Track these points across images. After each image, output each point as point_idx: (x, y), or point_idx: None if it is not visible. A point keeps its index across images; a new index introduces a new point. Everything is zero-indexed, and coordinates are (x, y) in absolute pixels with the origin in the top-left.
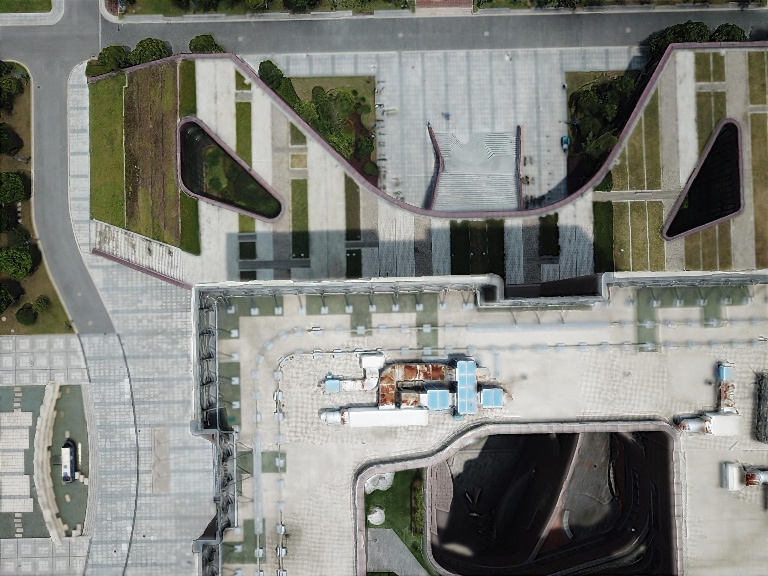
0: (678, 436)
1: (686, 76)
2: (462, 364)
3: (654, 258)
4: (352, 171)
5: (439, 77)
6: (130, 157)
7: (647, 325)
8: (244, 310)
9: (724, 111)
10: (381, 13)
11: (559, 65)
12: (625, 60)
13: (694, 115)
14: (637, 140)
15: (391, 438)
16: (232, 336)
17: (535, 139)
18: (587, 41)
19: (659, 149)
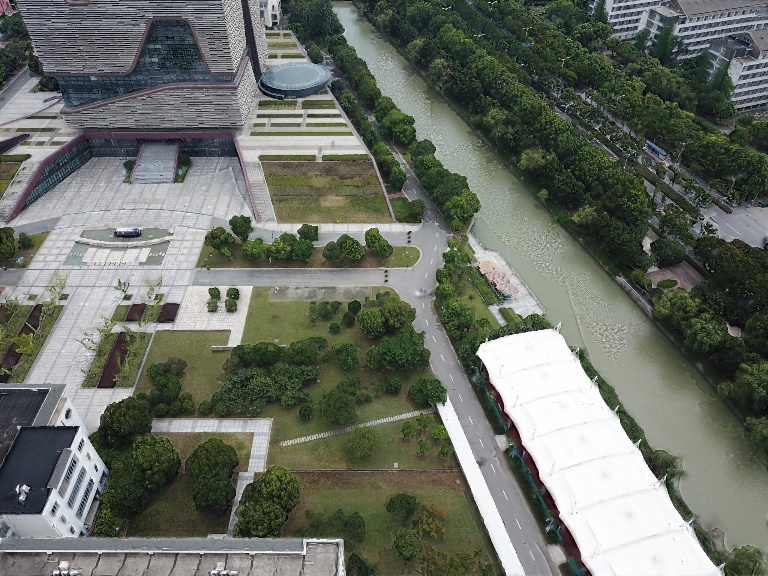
0: None
1: None
2: None
3: None
4: (24, 117)
5: (3, 120)
6: None
7: None
8: None
9: None
10: None
11: None
12: None
13: None
14: None
15: None
16: None
17: None
18: None
19: None
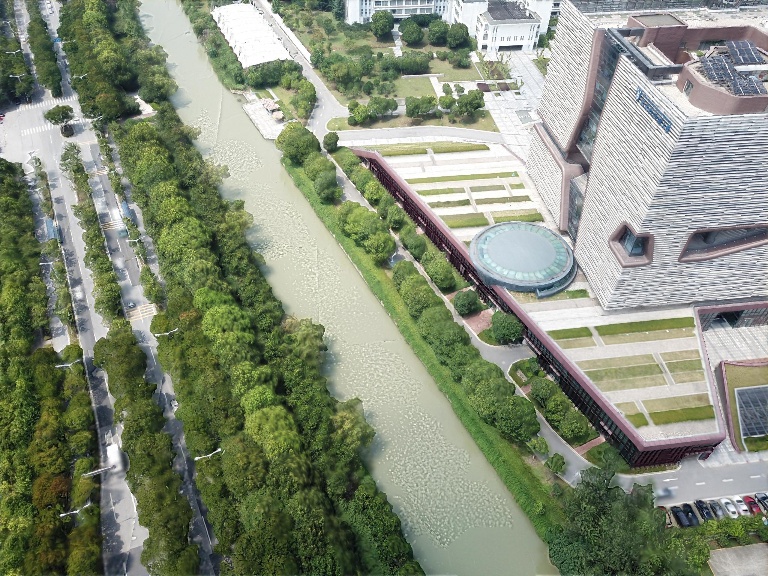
0: None
1: None
2: None
3: None
4: None
5: None
6: None
7: None
8: None
9: None
10: None
11: None
12: None
13: None
14: None
15: None
16: None
17: None
18: None
19: None
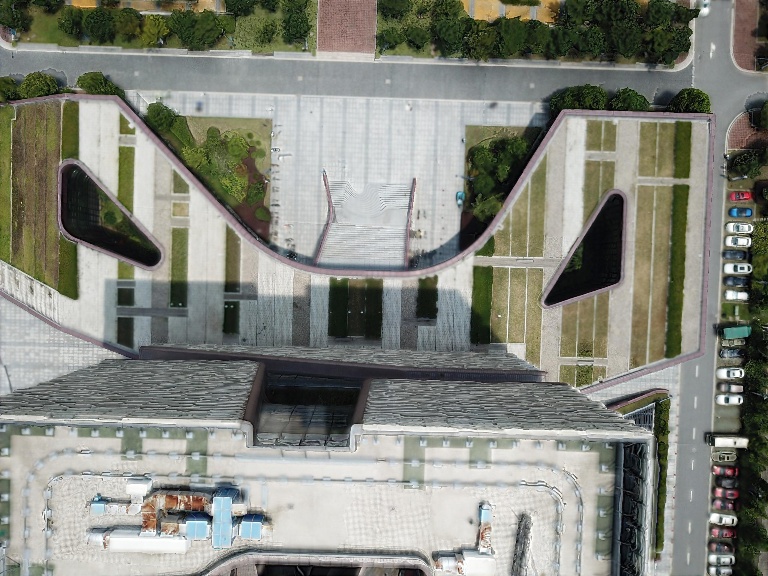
0: (432, 574)
1: (576, 143)
2: (218, 500)
3: (531, 325)
4: (234, 223)
5: (337, 124)
6: (16, 192)
7: (412, 464)
8: (16, 429)
9: (612, 181)
10: (282, 54)
11: (460, 118)
12: (527, 116)
13: (581, 184)
14: (522, 206)
15: (156, 560)
16: (2, 454)
17: (430, 192)
18: (490, 94)
19: (544, 216)
